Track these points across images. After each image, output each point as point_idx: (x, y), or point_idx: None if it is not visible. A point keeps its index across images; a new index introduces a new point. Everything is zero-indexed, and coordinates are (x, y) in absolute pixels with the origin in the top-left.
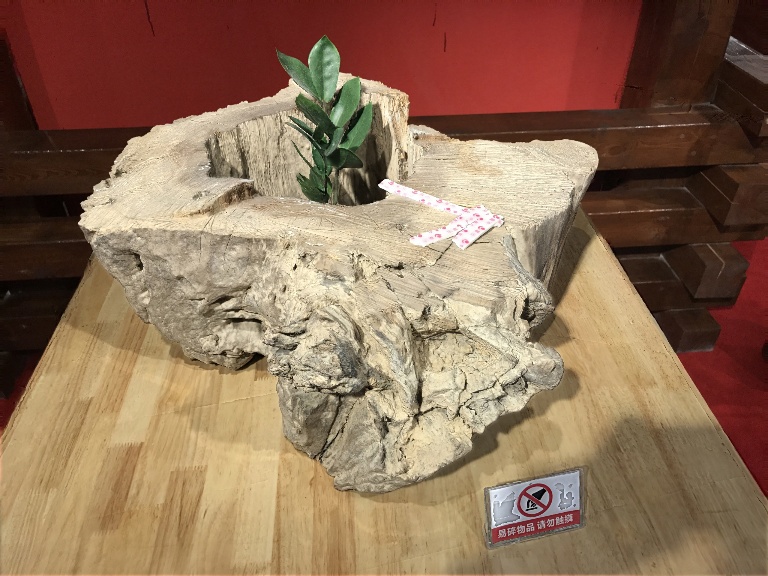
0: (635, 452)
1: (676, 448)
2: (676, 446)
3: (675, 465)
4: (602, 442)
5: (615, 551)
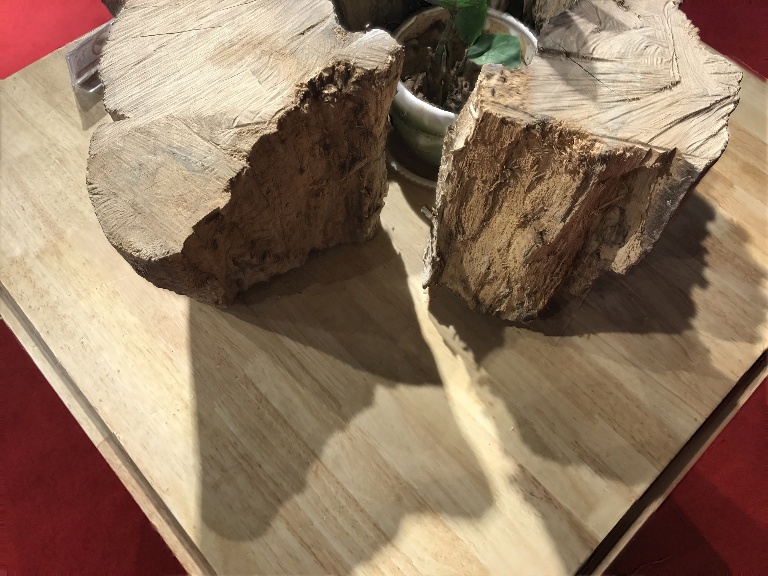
0: (45, 165)
1: (6, 190)
2: (7, 193)
3: (6, 173)
4: (78, 158)
5: (45, 82)
